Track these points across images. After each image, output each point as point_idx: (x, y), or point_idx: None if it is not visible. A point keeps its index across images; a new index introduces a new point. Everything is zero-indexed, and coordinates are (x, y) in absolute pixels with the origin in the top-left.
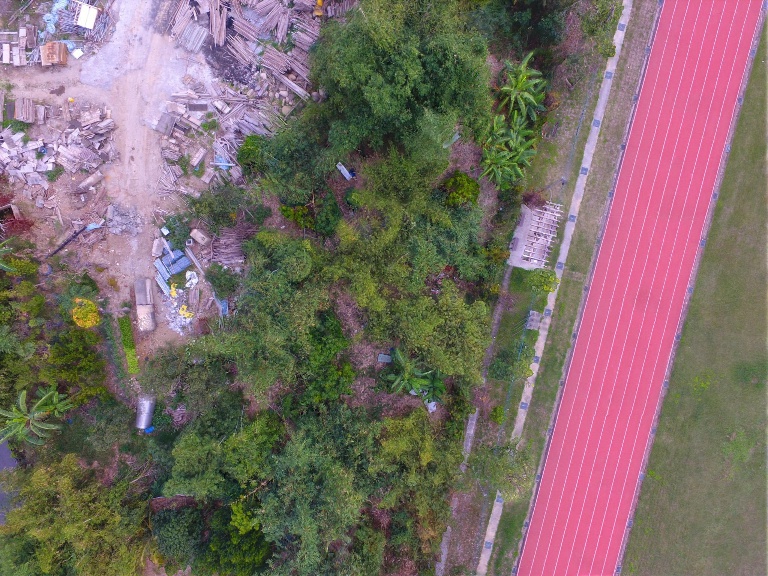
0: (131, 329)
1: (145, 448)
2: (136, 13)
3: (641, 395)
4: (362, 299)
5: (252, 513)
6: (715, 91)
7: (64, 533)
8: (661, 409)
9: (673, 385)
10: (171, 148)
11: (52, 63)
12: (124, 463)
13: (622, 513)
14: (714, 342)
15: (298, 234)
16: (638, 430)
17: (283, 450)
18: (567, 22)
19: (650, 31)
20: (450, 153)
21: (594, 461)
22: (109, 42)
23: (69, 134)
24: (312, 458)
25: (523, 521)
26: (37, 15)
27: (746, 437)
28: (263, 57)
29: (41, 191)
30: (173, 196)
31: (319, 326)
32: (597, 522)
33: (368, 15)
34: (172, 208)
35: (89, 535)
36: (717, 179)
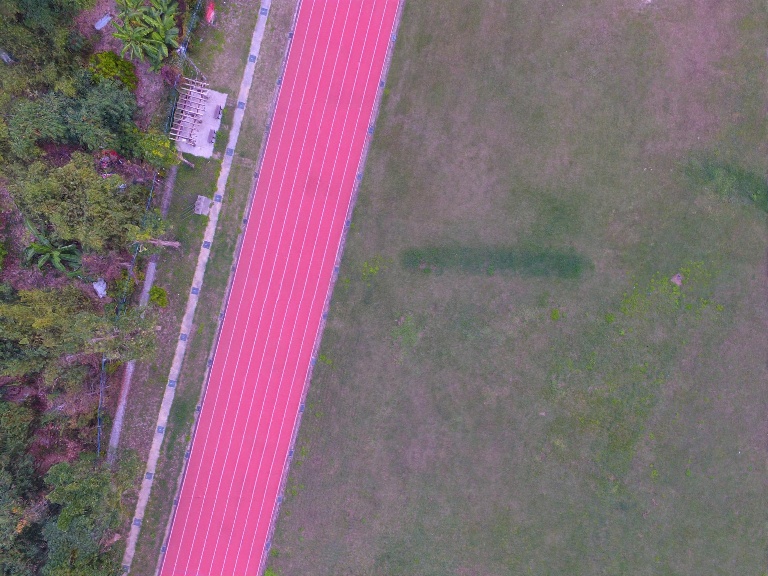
0: None
1: None
2: None
3: (312, 280)
4: None
5: None
6: None
7: None
8: (332, 294)
9: (343, 270)
10: None
11: None
12: None
13: (294, 397)
14: (382, 228)
15: None
16: (309, 315)
17: None
18: None
19: None
20: (105, 35)
21: (265, 346)
22: None
23: None
24: None
25: (195, 405)
26: None
27: (414, 321)
28: None
29: None
30: None
31: None
32: (269, 406)
33: None
34: None
35: None
36: (384, 68)
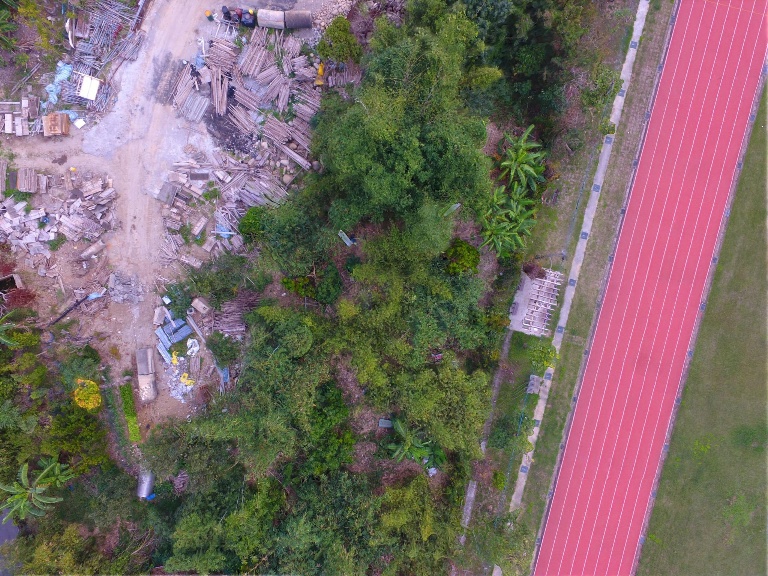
0: (132, 397)
1: (146, 515)
2: (138, 83)
3: (641, 458)
4: (363, 376)
5: None
6: (715, 156)
7: None
8: (661, 472)
9: (673, 448)
10: (172, 217)
11: (54, 134)
12: (125, 530)
13: None
14: (714, 406)
15: (299, 302)
16: (638, 493)
17: (284, 523)
18: (567, 96)
19: (650, 96)
20: (450, 220)
21: (594, 524)
22: (111, 112)
23: (71, 204)
24: (313, 534)
25: None
26: (39, 86)
27: (746, 501)
28: (264, 127)
29: (43, 260)
30: (174, 264)
31: (320, 396)
32: None
33: (369, 107)
34: (173, 276)
35: None
36: (717, 243)
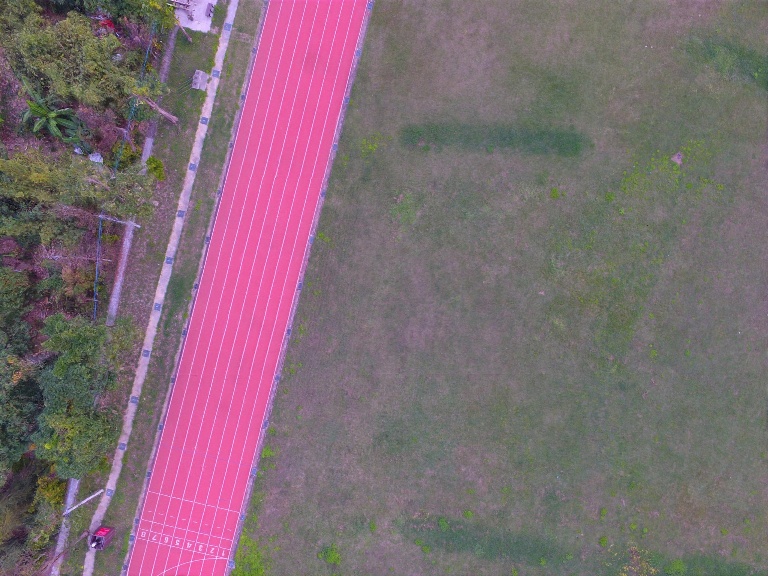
0: None
1: None
2: None
3: (310, 157)
4: None
5: None
6: None
7: None
8: (330, 172)
9: (341, 147)
10: None
11: None
12: None
13: (292, 275)
14: (381, 105)
15: None
16: (307, 192)
17: None
18: None
19: None
20: None
21: (263, 223)
22: None
23: None
24: None
25: (192, 282)
26: None
27: (413, 199)
28: None
29: None
30: None
31: None
32: (267, 284)
33: None
34: None
35: None
36: None
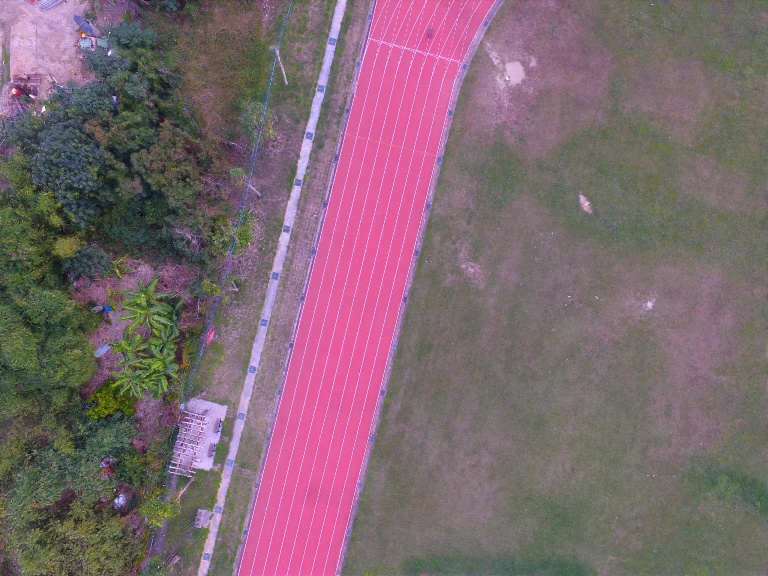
0: None
1: None
2: None
3: None
4: None
5: None
6: (381, 290)
7: None
8: None
9: None
10: None
11: None
12: None
13: None
14: (384, 537)
15: None
16: None
17: None
18: (192, 249)
19: (315, 233)
20: (104, 361)
21: None
22: None
23: None
24: None
25: None
26: None
27: None
28: None
29: None
30: None
31: None
32: None
33: None
34: None
35: None
36: (385, 376)
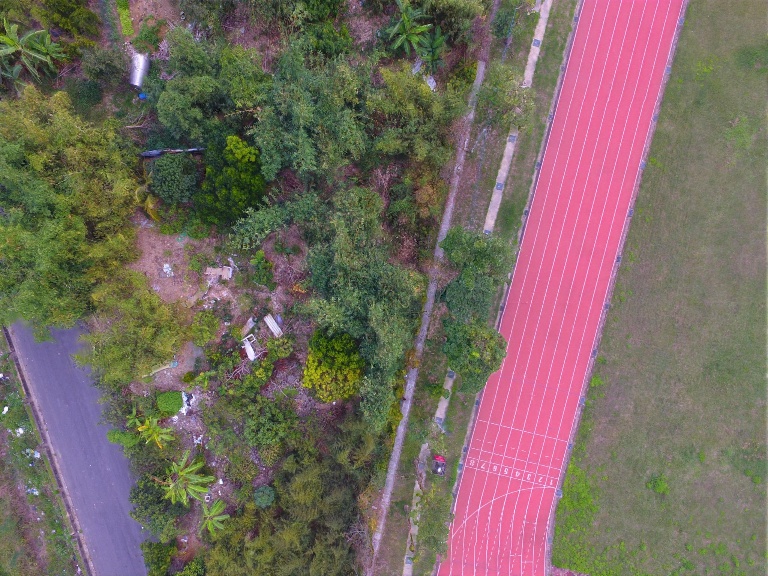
0: None
1: None
2: None
3: (643, 81)
4: None
5: (248, 143)
6: None
7: (56, 142)
8: (663, 95)
9: (675, 70)
10: None
11: None
12: None
13: (623, 202)
14: (717, 26)
15: None
16: (640, 117)
17: None
18: None
19: None
20: None
21: (595, 148)
22: None
23: None
24: (309, 78)
25: (523, 209)
26: None
27: (749, 123)
28: None
29: None
30: None
31: None
32: (597, 210)
33: None
34: None
35: (82, 151)
36: None
